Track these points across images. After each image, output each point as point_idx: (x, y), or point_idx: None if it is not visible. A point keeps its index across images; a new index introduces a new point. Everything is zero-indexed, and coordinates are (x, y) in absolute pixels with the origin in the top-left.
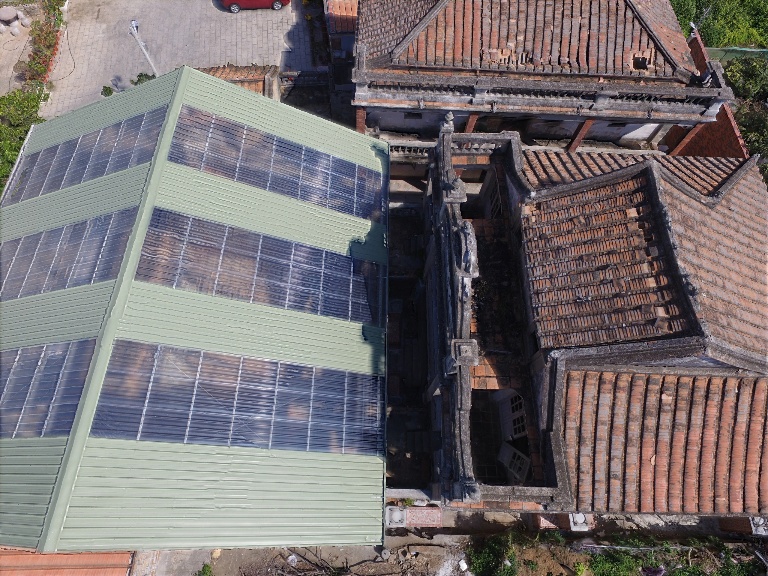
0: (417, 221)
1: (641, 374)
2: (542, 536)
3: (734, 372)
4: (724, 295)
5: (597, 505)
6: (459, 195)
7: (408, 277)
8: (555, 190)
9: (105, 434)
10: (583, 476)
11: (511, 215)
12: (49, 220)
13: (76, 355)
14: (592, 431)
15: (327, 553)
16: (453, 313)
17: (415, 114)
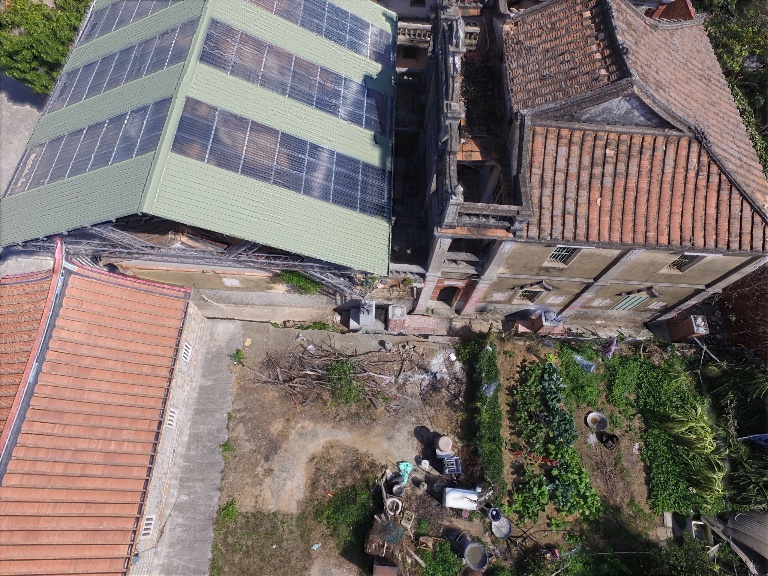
0: (420, 88)
1: (590, 131)
2: (519, 336)
3: (662, 131)
4: (656, 75)
5: (554, 233)
6: (453, 13)
7: (411, 128)
8: (529, 9)
9: (182, 153)
10: (544, 211)
11: (496, 46)
12: (122, 44)
13: (156, 109)
14: (552, 178)
15: (340, 345)
16: (446, 94)
17: (420, 1)
